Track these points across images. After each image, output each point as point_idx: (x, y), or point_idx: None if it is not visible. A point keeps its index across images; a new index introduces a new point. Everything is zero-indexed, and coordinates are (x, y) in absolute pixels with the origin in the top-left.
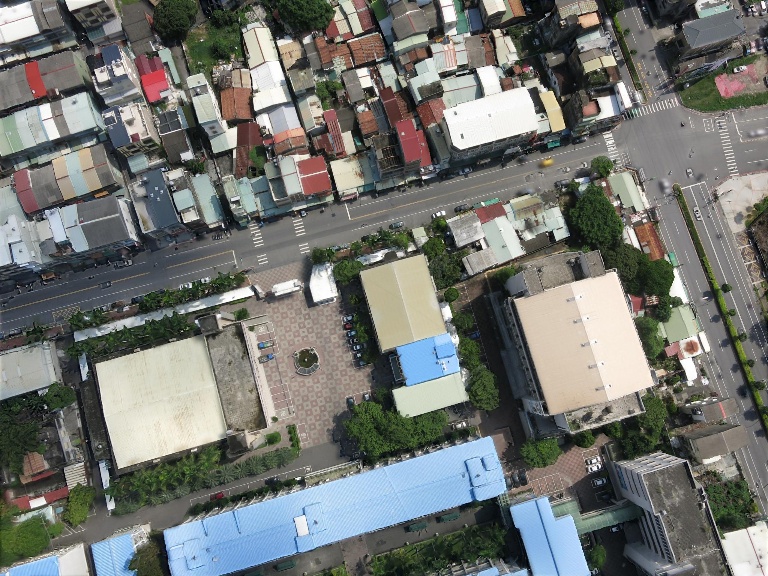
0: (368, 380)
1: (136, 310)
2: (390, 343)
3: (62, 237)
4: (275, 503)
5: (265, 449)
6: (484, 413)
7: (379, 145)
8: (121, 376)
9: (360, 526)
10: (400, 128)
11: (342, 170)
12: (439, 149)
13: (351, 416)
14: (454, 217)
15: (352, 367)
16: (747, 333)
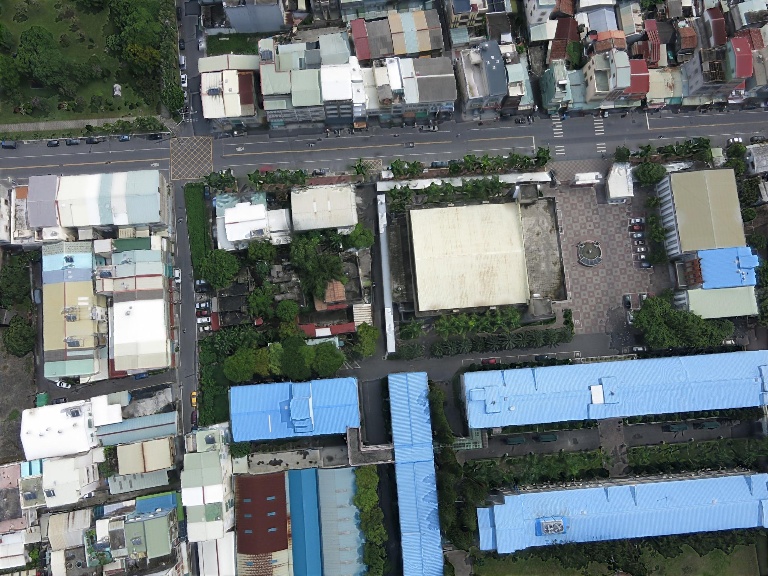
0: (646, 282)
1: (435, 174)
2: (691, 246)
3: (397, 86)
4: (574, 369)
5: (540, 327)
6: (753, 335)
7: (706, 58)
8: (434, 226)
9: (650, 407)
10: (736, 44)
11: (654, 79)
12: (757, 75)
13: (625, 313)
14: (754, 144)
15: (632, 267)
16: None
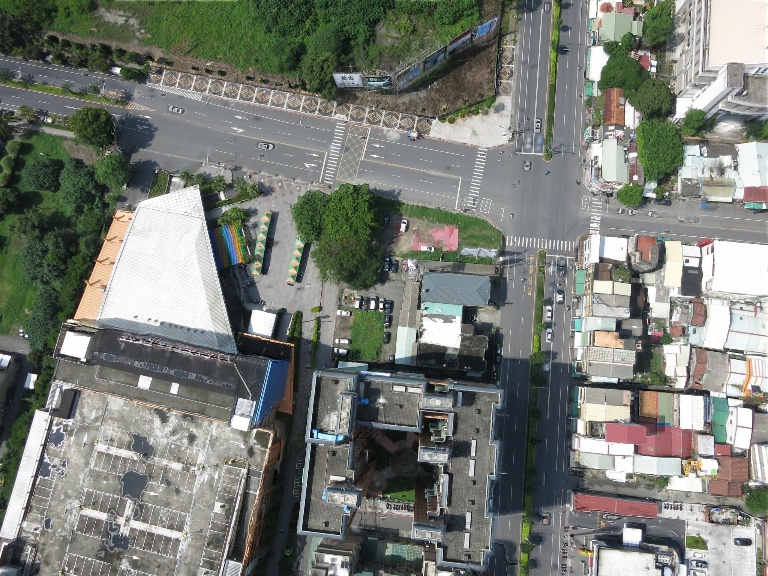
0: None
1: None
2: None
3: None
4: None
5: None
6: None
7: None
8: None
9: None
10: None
11: None
12: None
13: None
14: None
15: None
16: (542, 8)
